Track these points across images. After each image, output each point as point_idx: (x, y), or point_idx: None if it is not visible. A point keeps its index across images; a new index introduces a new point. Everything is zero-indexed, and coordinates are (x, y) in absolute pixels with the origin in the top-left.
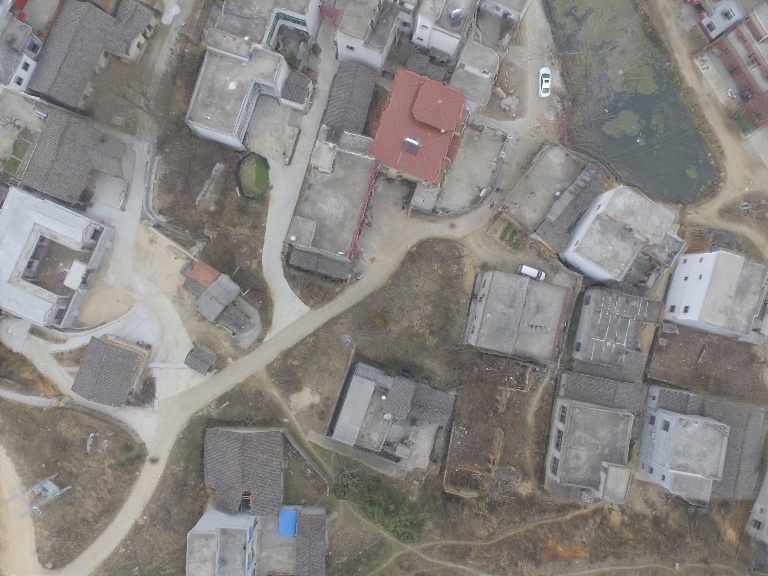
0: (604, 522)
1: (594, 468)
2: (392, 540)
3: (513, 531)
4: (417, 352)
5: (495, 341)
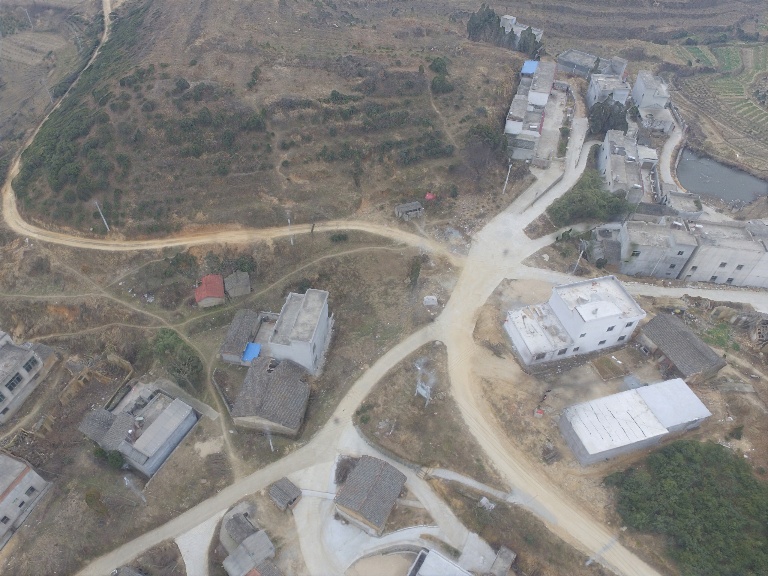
0: (27, 329)
1: (0, 357)
2: (182, 334)
3: (93, 330)
4: (90, 475)
5: (8, 467)
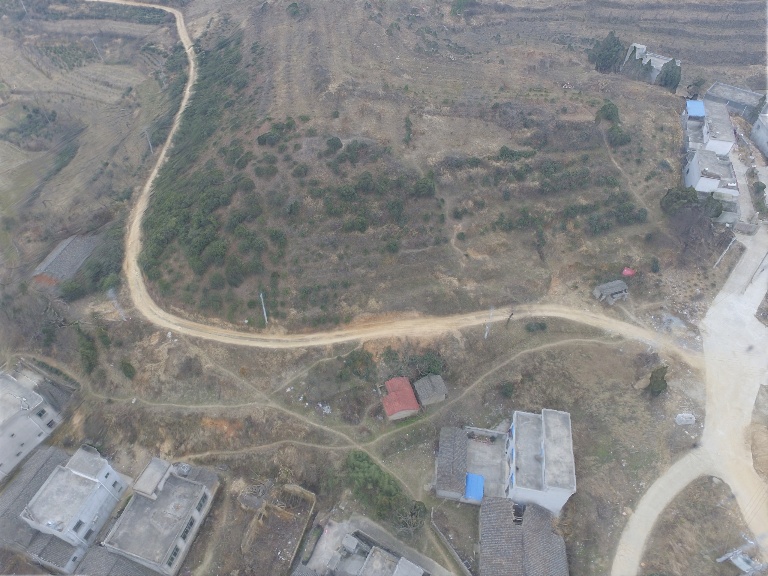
0: (178, 444)
1: (166, 495)
2: (374, 456)
3: (261, 448)
4: None
5: None
